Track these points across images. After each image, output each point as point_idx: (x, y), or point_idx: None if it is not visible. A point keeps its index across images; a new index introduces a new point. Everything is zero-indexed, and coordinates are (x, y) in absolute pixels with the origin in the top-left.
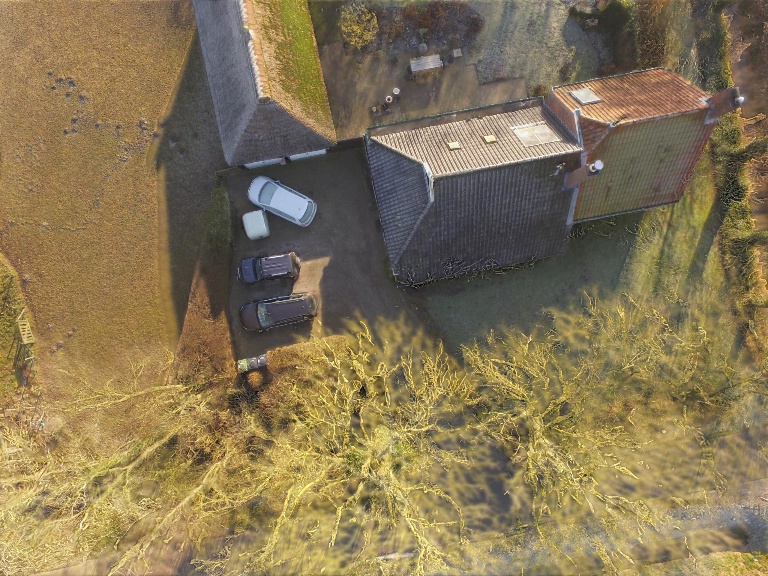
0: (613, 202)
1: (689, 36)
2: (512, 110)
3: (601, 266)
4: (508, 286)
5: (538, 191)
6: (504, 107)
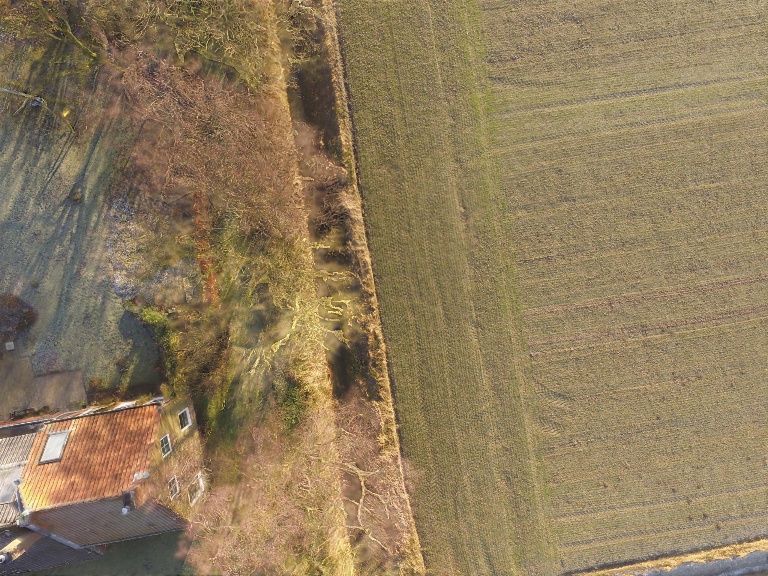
0: (111, 534)
1: (256, 326)
2: (21, 433)
3: (163, 555)
4: (67, 575)
5: (4, 542)
6: (12, 430)
